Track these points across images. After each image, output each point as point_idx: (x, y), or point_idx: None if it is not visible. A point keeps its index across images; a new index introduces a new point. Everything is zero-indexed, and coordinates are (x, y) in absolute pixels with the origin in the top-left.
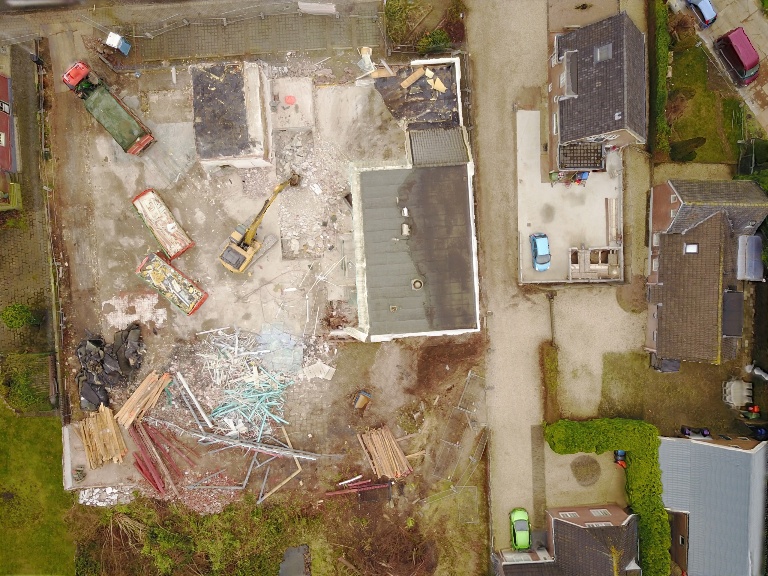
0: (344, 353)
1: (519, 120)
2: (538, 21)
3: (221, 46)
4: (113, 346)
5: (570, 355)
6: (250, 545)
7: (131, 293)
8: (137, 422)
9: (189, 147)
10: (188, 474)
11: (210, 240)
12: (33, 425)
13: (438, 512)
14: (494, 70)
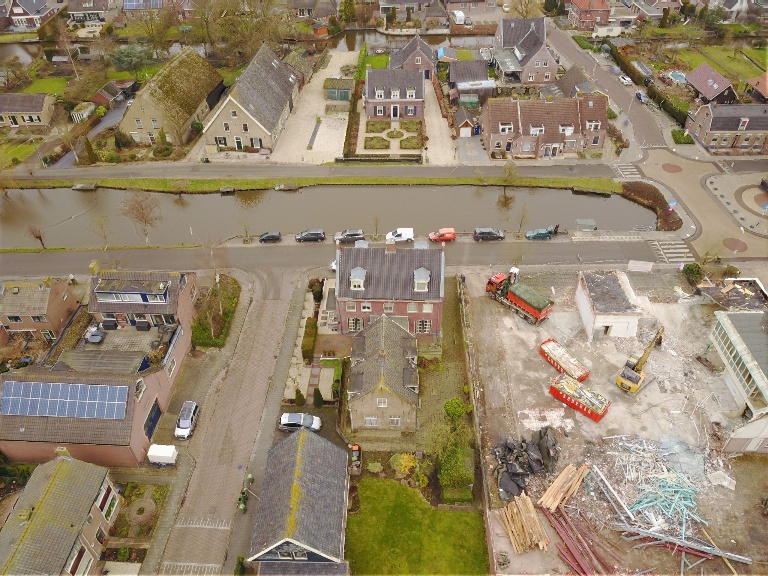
0: (738, 469)
1: None
2: None
3: None
4: (532, 441)
5: None
6: None
7: (541, 407)
8: (560, 508)
9: (571, 325)
10: (618, 569)
11: (599, 376)
12: (447, 518)
13: None
14: None
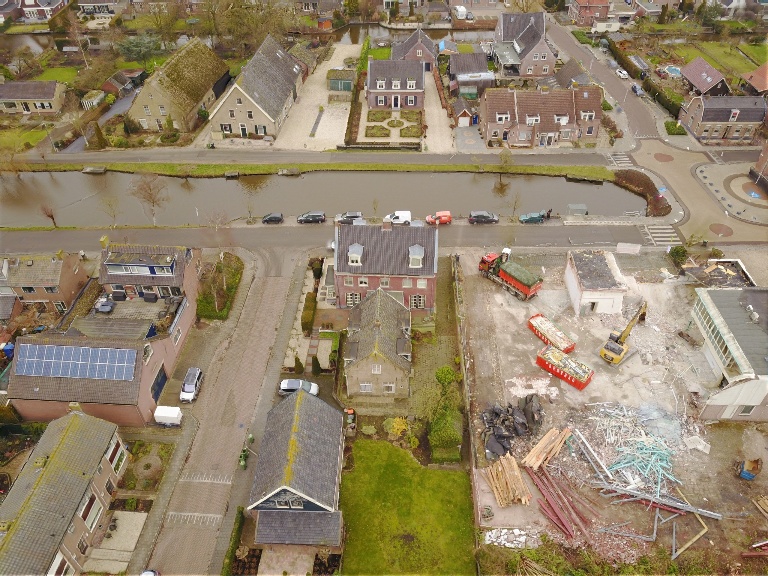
0: (713, 435)
1: None
2: None
3: None
4: None
5: None
6: None
7: (528, 376)
8: (543, 467)
9: (559, 301)
10: (595, 522)
11: (584, 349)
12: (436, 477)
13: None
14: None
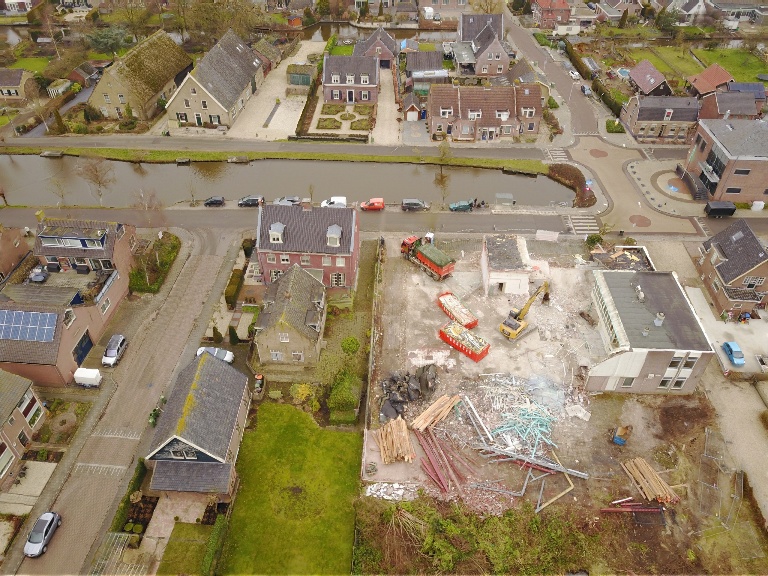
0: (596, 405)
1: (688, 291)
2: (682, 253)
3: None
4: (416, 375)
5: None
6: (530, 555)
7: (430, 348)
8: (429, 429)
9: (472, 282)
10: (470, 478)
11: (488, 325)
12: (332, 437)
13: (717, 547)
14: (662, 269)
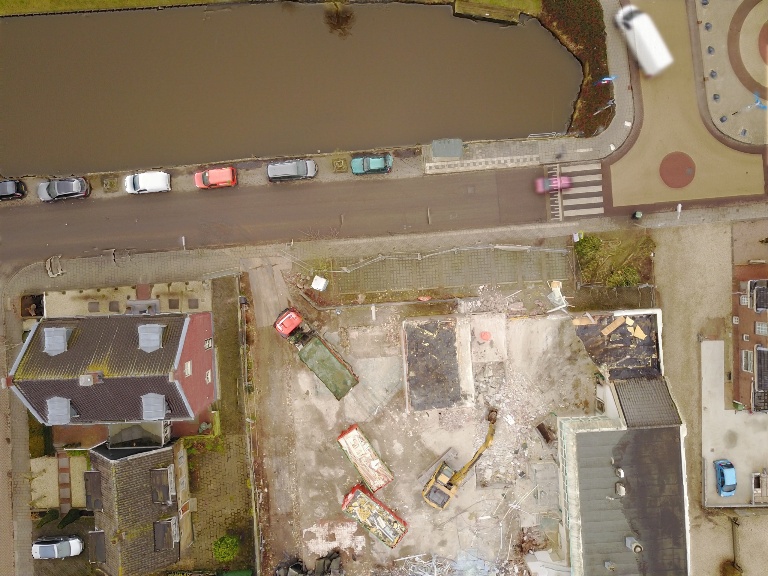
0: None
1: (704, 350)
2: (723, 254)
3: (415, 280)
4: (315, 573)
5: (750, 573)
6: None
7: (331, 521)
8: None
9: (388, 381)
10: None
11: (407, 470)
12: None
13: None
14: (680, 302)
